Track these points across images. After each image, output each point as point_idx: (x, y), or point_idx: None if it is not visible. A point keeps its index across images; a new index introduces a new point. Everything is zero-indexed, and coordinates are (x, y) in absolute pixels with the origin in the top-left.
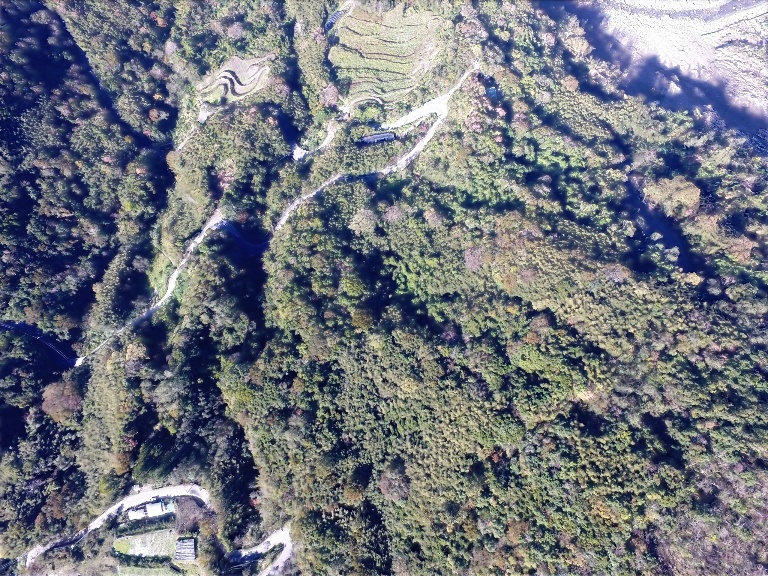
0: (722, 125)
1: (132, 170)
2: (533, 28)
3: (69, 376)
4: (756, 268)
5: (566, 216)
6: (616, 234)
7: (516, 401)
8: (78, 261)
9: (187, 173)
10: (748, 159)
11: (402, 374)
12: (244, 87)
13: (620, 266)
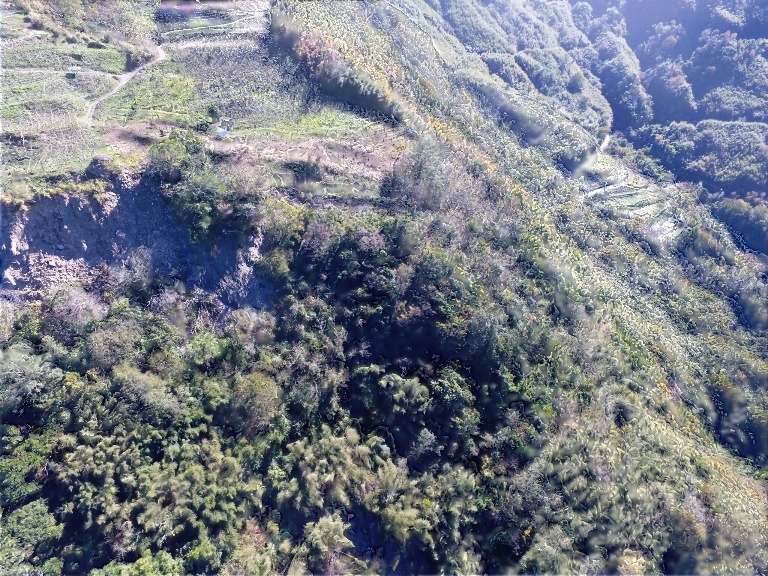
0: None
1: None
2: None
3: None
4: None
5: None
6: None
7: None
8: None
9: None
10: None
11: None
12: None
13: None
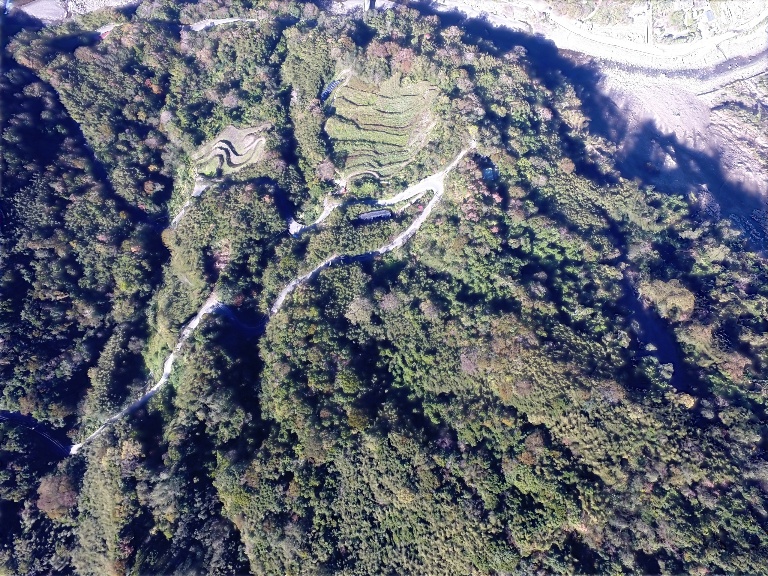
0: (717, 209)
1: (127, 248)
2: (530, 102)
3: (64, 466)
4: (749, 387)
5: (561, 318)
6: (611, 343)
7: (511, 526)
8: (73, 343)
9: (183, 253)
10: (742, 254)
11: (398, 482)
12: (240, 157)
13: (615, 385)
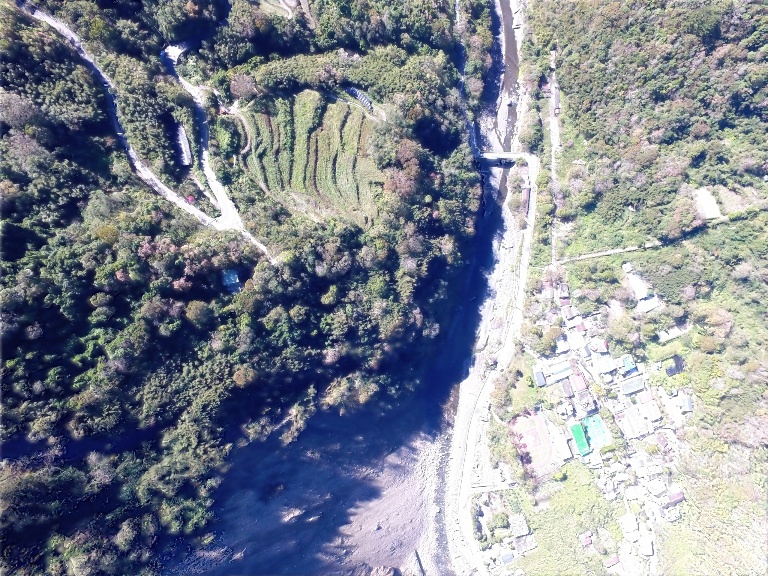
0: (193, 569)
1: None
2: (350, 335)
3: None
4: None
5: None
6: None
7: None
8: None
9: None
10: None
11: None
12: None
13: None
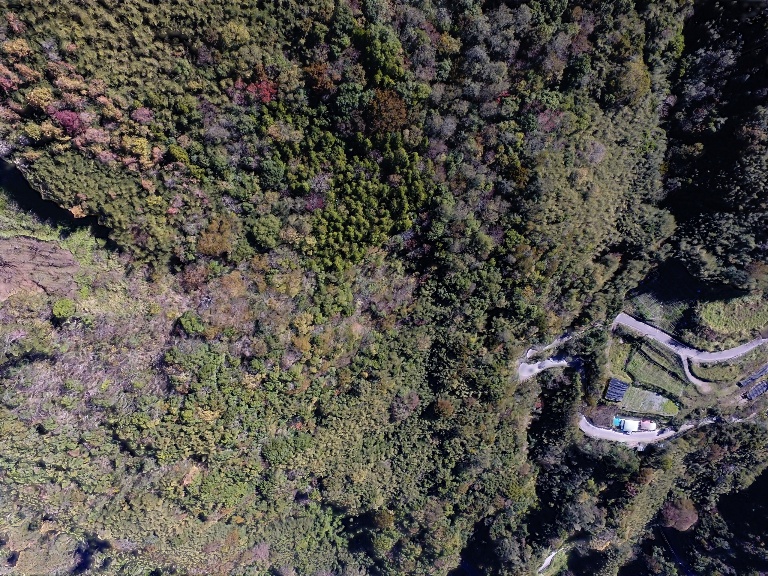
0: None
1: None
2: None
3: None
4: None
5: None
6: None
7: None
8: None
9: None
10: None
11: None
12: None
13: None
